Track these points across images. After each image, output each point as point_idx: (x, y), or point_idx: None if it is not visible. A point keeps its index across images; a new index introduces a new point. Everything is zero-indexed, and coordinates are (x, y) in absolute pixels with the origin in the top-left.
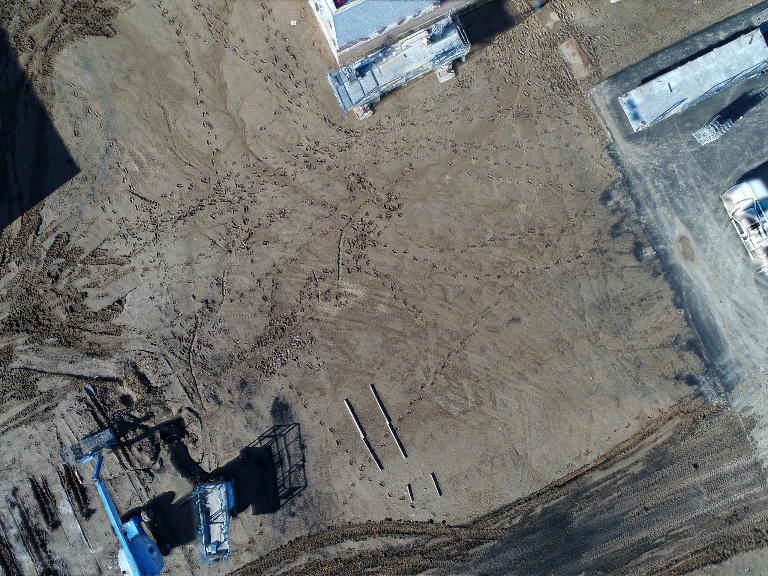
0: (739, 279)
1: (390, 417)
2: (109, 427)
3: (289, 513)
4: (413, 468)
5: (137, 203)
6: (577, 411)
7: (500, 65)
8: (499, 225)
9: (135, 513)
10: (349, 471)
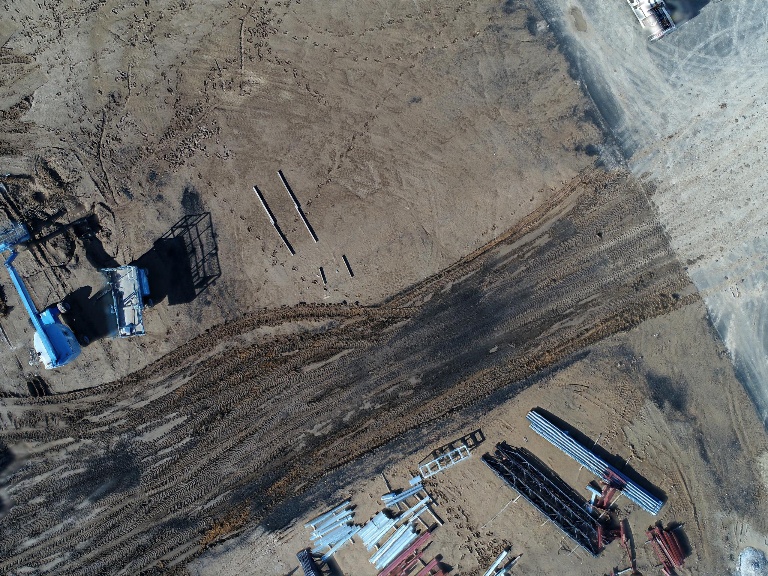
0: (632, 47)
1: (299, 202)
2: (23, 224)
3: (205, 302)
4: (324, 251)
5: (39, 1)
6: (482, 187)
7: None
8: (396, 7)
9: (52, 307)
10: (262, 258)
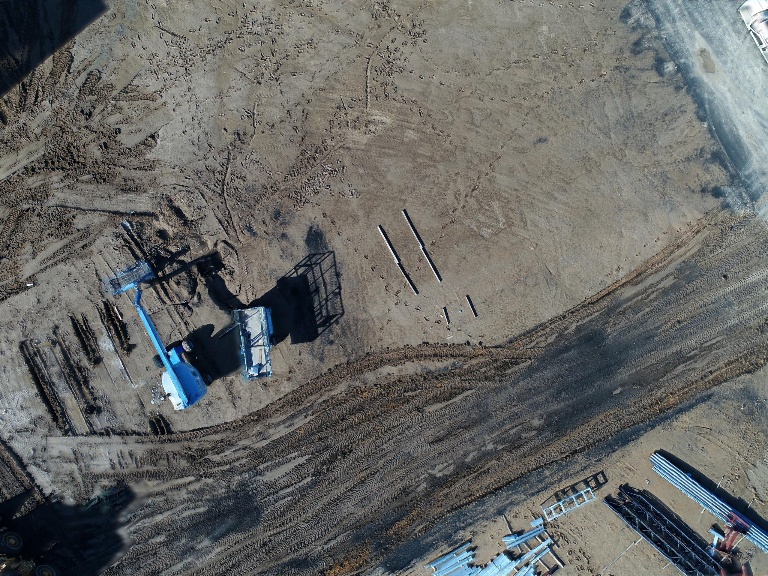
0: (760, 90)
1: (423, 242)
2: (147, 262)
3: (327, 341)
4: (448, 291)
5: (166, 39)
6: (607, 228)
7: None
8: (523, 47)
9: (176, 345)
10: (385, 297)
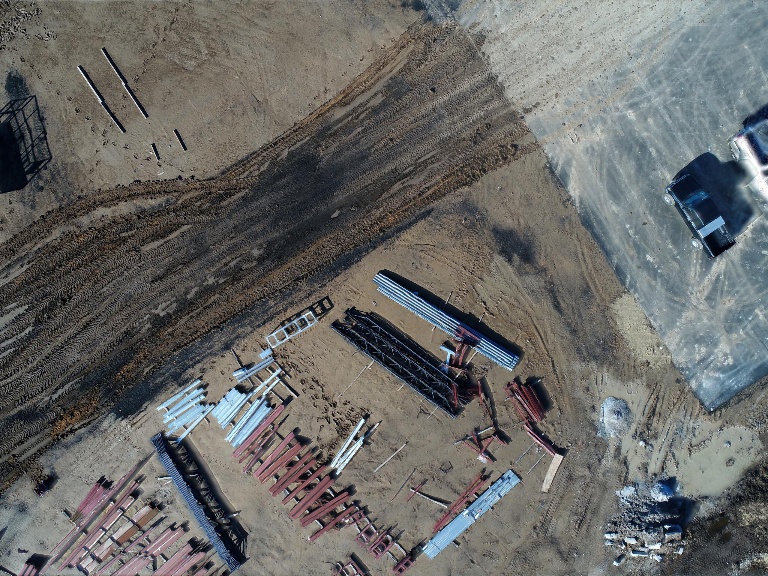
0: None
1: (126, 79)
2: None
3: (37, 187)
4: (155, 127)
5: None
6: (310, 50)
7: None
8: None
9: None
10: (92, 138)
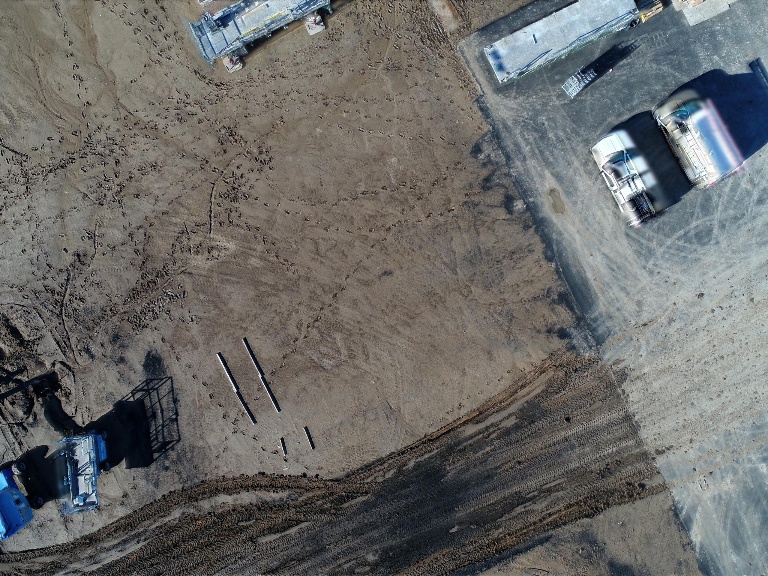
0: (609, 232)
1: (263, 371)
2: None
3: (162, 467)
4: (286, 422)
5: (8, 156)
6: (450, 365)
7: (370, 18)
8: (370, 178)
9: (7, 466)
10: (222, 425)
